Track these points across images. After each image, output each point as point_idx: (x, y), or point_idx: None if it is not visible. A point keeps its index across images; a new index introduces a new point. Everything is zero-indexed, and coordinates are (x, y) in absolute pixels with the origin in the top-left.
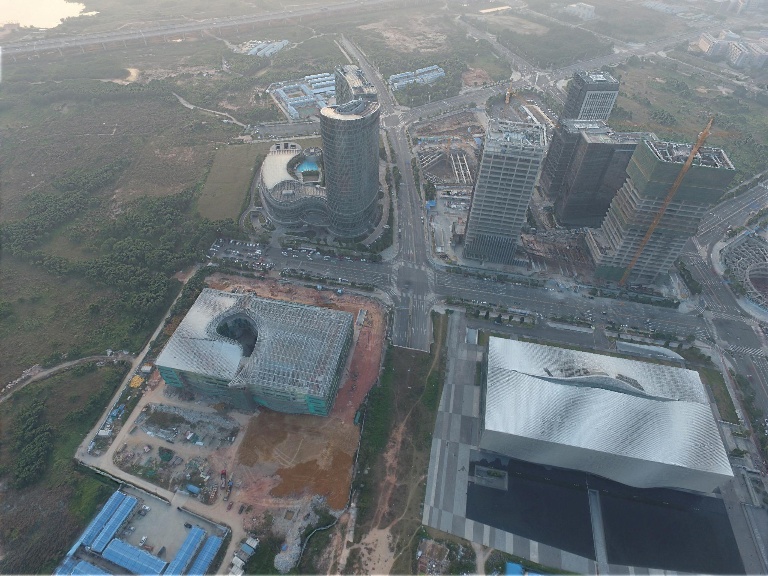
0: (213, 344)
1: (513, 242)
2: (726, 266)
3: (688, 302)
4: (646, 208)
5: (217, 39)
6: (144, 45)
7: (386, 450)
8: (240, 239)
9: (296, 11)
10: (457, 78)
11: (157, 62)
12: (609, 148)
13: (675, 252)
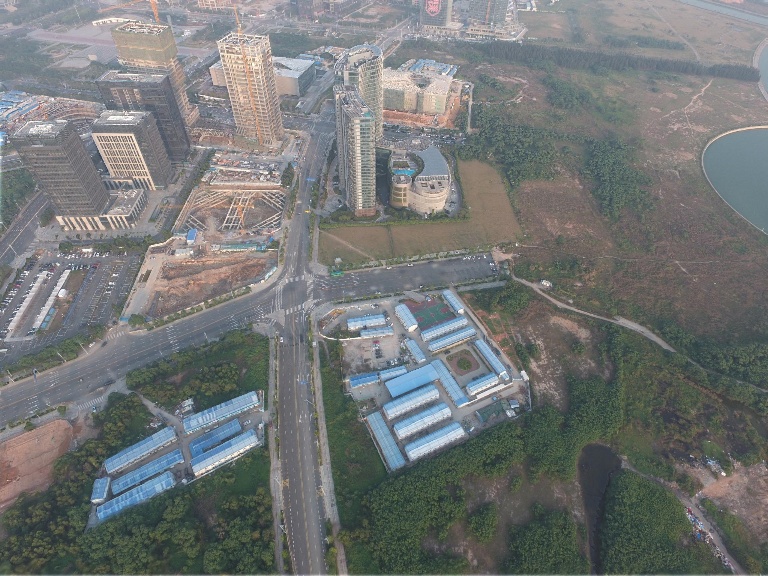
0: None
1: None
2: None
3: None
4: None
5: None
6: None
7: None
8: None
9: None
10: None
11: None
12: None
13: None
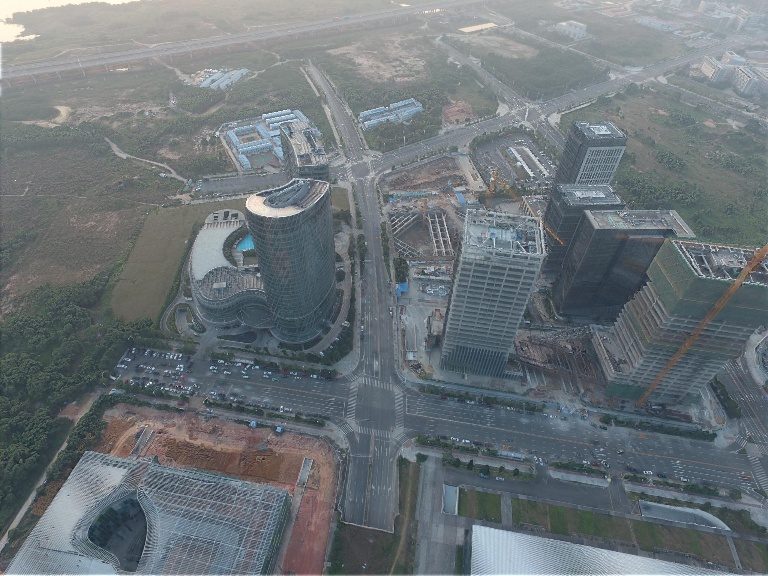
0: (79, 561)
1: (503, 355)
2: (765, 370)
3: (725, 430)
4: (675, 326)
5: (167, 68)
6: (82, 76)
7: None
8: (158, 348)
9: (259, 34)
10: (436, 114)
11: (94, 98)
12: (621, 234)
13: (710, 373)
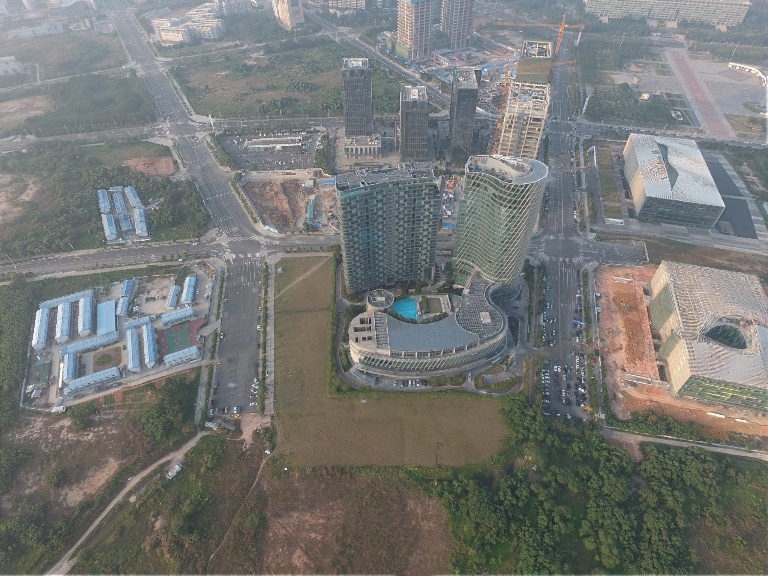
0: (763, 348)
1: None
2: None
3: None
4: None
5: None
6: None
7: (741, 269)
8: None
9: None
10: None
11: None
12: None
13: None
